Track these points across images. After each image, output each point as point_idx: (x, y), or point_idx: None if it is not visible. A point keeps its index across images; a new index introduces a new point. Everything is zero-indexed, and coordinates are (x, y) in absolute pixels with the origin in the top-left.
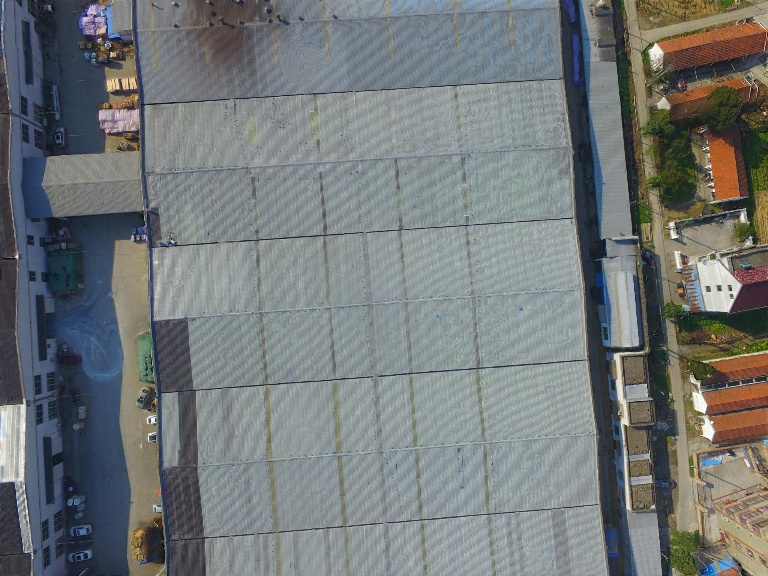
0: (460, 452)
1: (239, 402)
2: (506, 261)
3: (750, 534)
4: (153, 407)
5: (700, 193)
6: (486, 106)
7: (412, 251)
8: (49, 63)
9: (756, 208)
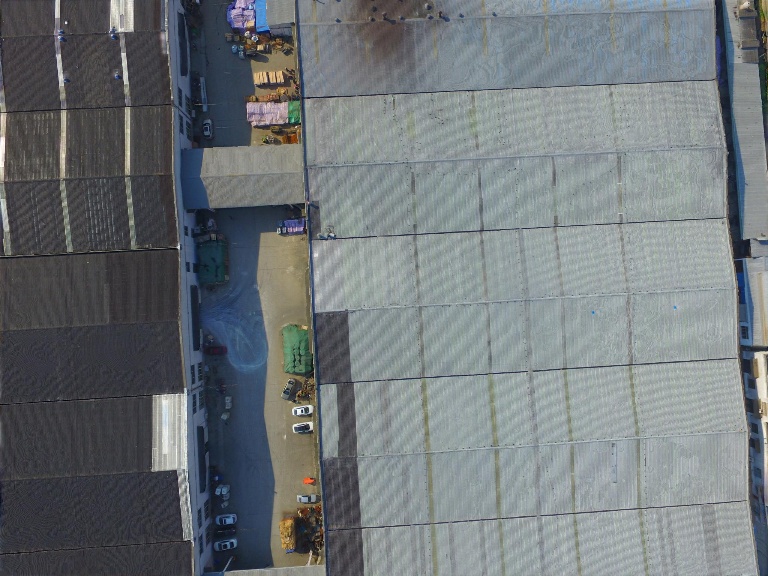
0: (614, 447)
1: (397, 394)
2: (660, 259)
3: None
4: (298, 398)
5: None
6: (640, 105)
7: (567, 248)
8: (196, 55)
9: None
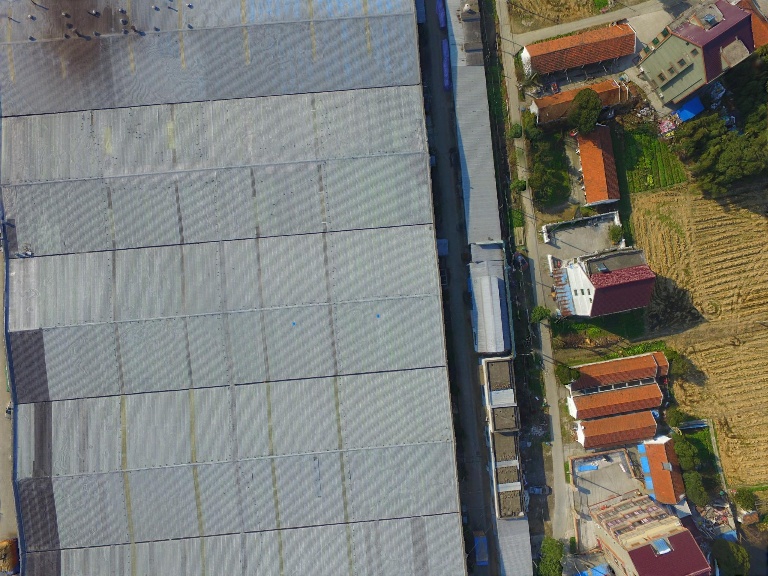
0: (316, 460)
1: (95, 412)
2: (363, 268)
3: (613, 541)
4: None
5: (574, 196)
6: (343, 113)
7: (269, 259)
8: None
9: (632, 210)
